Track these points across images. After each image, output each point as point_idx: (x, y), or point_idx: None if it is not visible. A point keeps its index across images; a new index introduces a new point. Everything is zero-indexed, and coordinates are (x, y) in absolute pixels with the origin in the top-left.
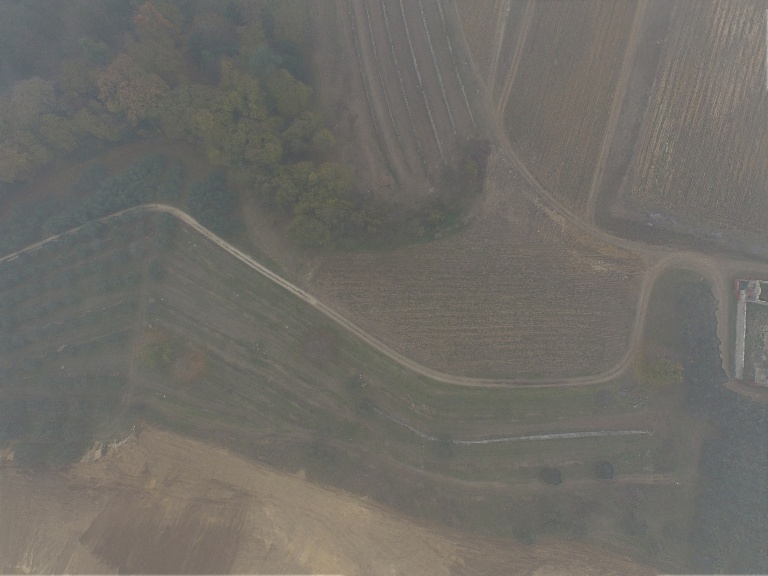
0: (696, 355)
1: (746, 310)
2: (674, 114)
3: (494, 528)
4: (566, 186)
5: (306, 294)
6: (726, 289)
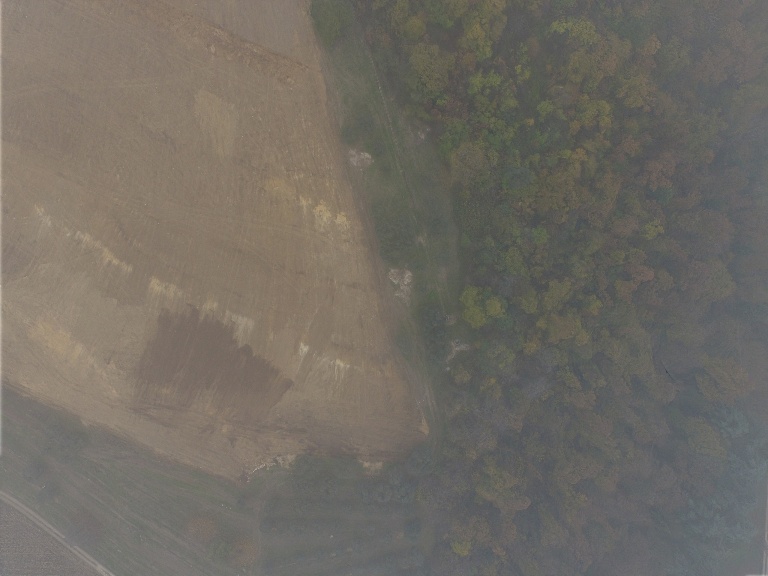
0: None
1: None
2: None
3: None
4: None
5: None
6: None
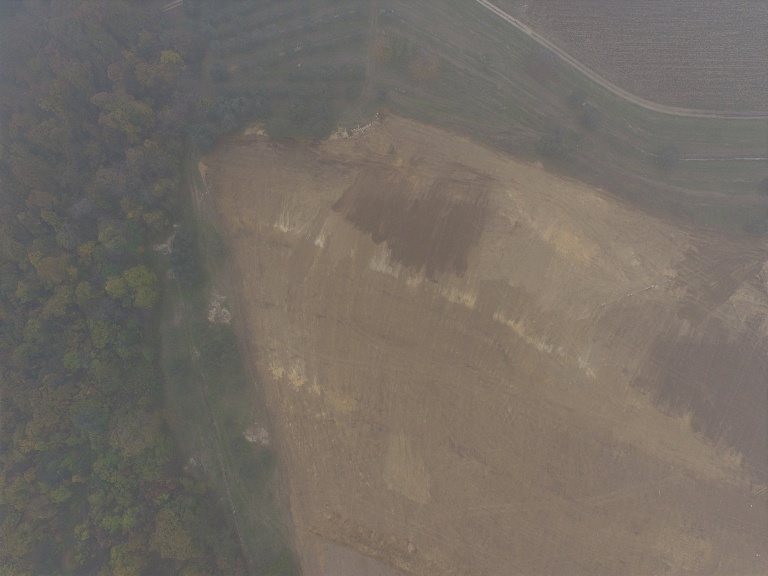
0: None
1: None
2: None
3: (723, 224)
4: None
5: (522, 24)
6: None
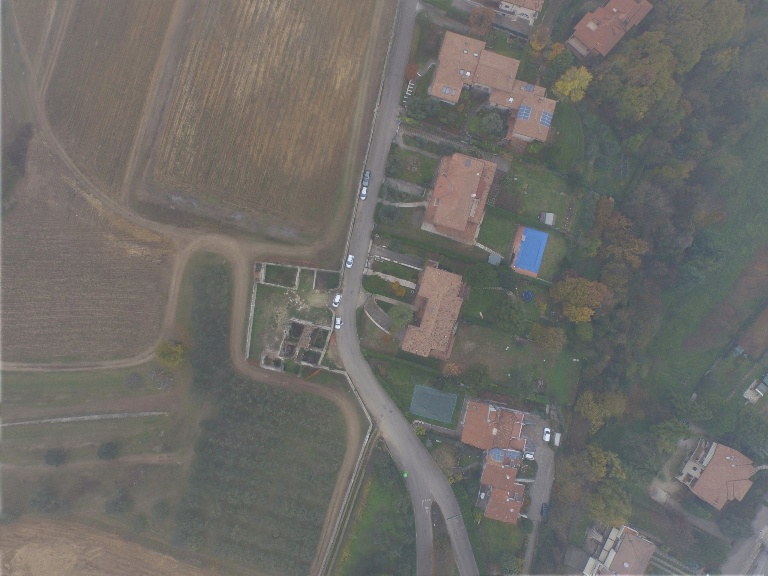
0: (200, 337)
1: (262, 292)
2: (197, 95)
3: None
4: (102, 169)
5: None
6: (247, 271)
